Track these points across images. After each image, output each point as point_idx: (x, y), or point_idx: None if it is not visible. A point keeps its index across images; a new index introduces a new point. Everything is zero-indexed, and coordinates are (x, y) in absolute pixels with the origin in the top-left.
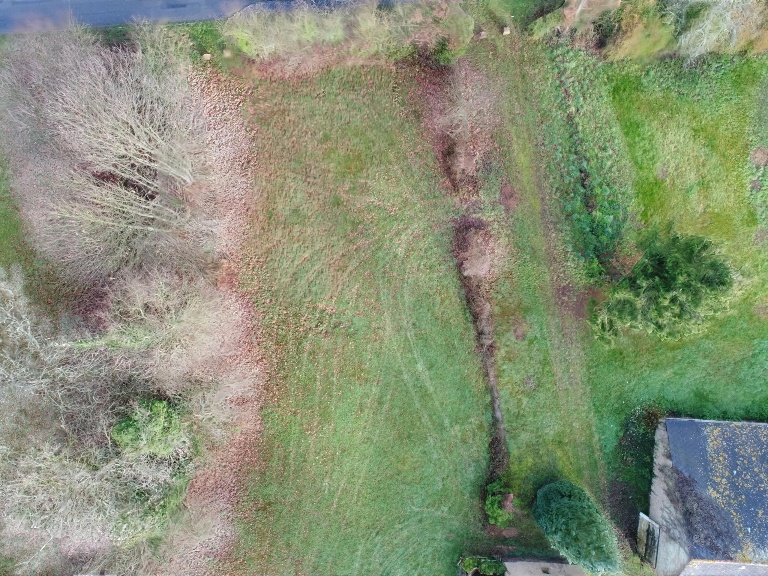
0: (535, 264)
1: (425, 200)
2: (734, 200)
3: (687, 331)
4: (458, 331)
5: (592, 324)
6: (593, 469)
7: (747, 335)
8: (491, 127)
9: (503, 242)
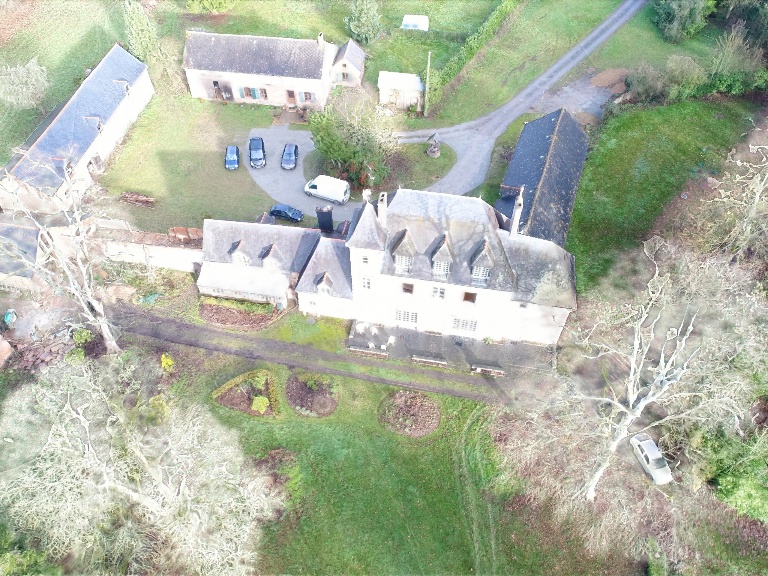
0: (178, 7)
1: None
2: (278, 1)
3: None
4: None
5: None
6: (178, 64)
7: (272, 32)
8: None
9: (166, 1)
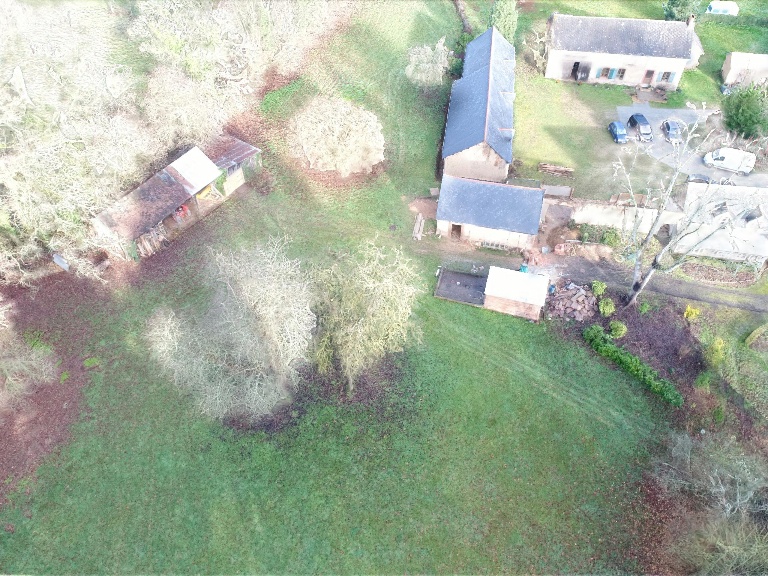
0: None
1: None
2: None
3: None
4: (447, 7)
5: None
6: None
7: None
8: None
9: None
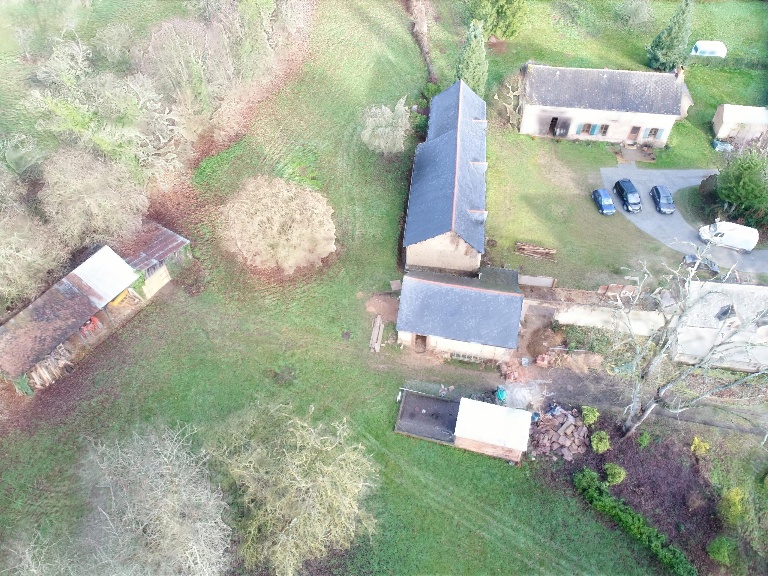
0: (450, 35)
1: (397, 17)
2: None
3: (513, 2)
4: (411, 49)
5: (473, 19)
6: (486, 97)
7: (562, 61)
8: (429, 3)
9: (434, 28)
